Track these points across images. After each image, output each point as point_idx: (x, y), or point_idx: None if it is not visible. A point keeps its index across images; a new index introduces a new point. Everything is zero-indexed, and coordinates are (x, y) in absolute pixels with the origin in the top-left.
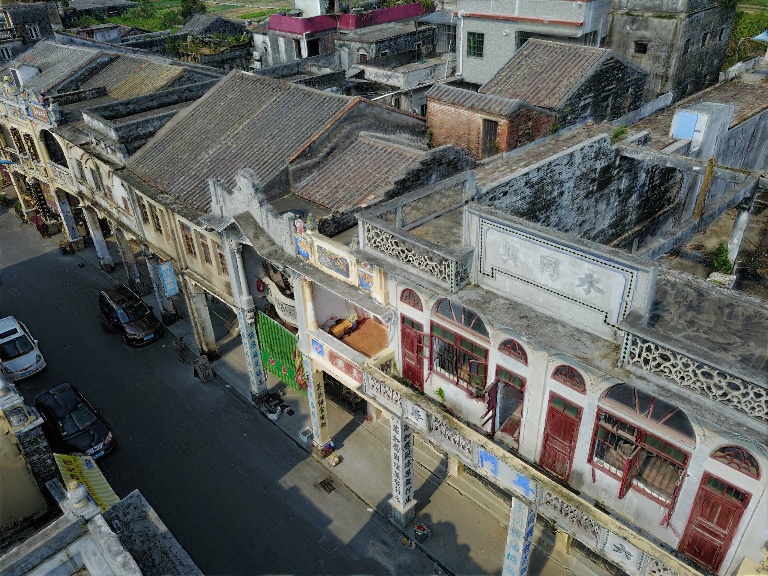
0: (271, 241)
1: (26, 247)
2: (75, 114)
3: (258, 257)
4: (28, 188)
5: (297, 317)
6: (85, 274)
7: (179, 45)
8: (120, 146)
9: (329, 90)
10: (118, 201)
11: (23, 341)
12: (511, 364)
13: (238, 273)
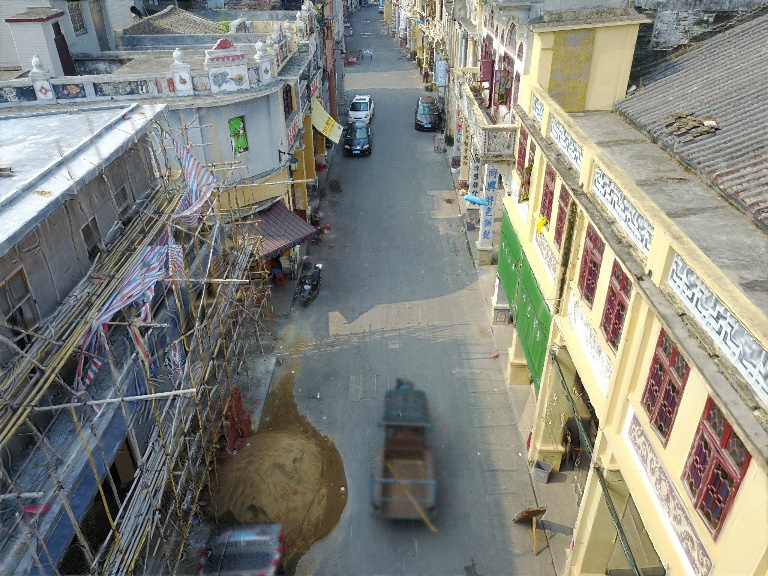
0: (466, 14)
1: (410, 84)
2: None
3: None
4: None
5: None
6: None
7: None
8: None
9: None
10: None
11: (365, 105)
12: (495, 43)
13: None
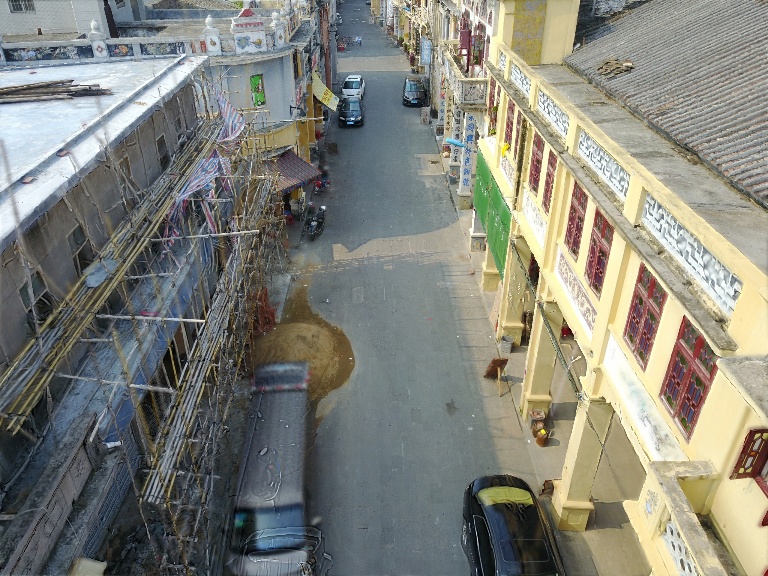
0: None
1: (398, 67)
2: None
3: None
4: None
5: None
6: None
7: None
8: None
9: None
10: None
11: (357, 84)
12: None
13: None
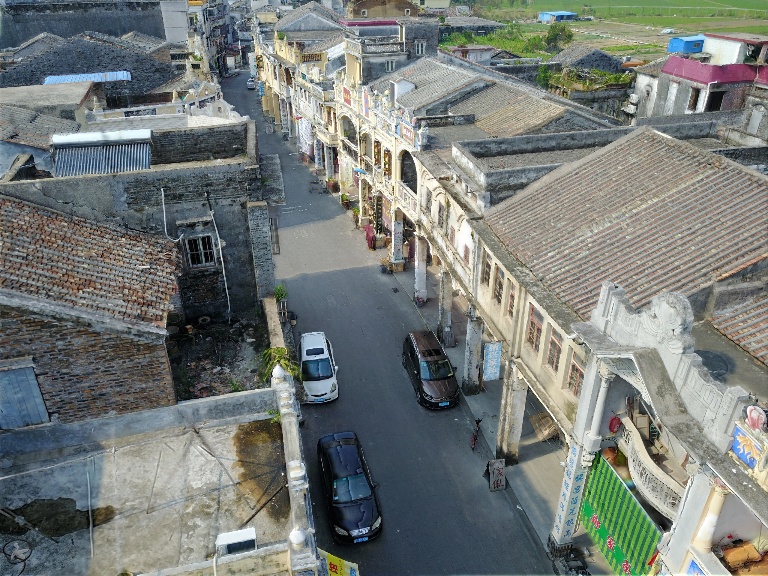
0: (681, 406)
1: (352, 254)
2: (439, 140)
3: (626, 389)
4: (370, 197)
5: (679, 518)
6: (397, 301)
7: (551, 76)
8: (485, 194)
9: (754, 167)
10: (459, 247)
11: (325, 364)
12: None
13: (595, 404)
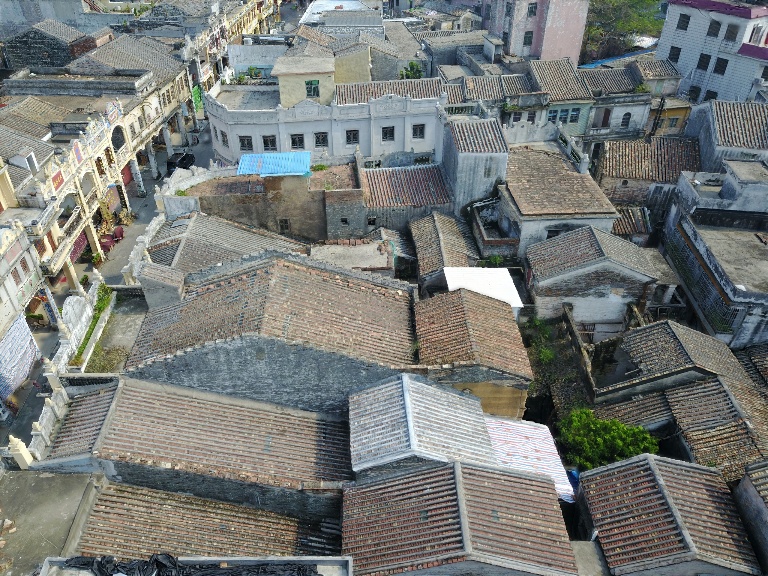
0: None
1: None
2: None
3: None
4: None
5: None
6: None
7: None
8: None
9: None
10: (153, 116)
11: None
12: None
13: None
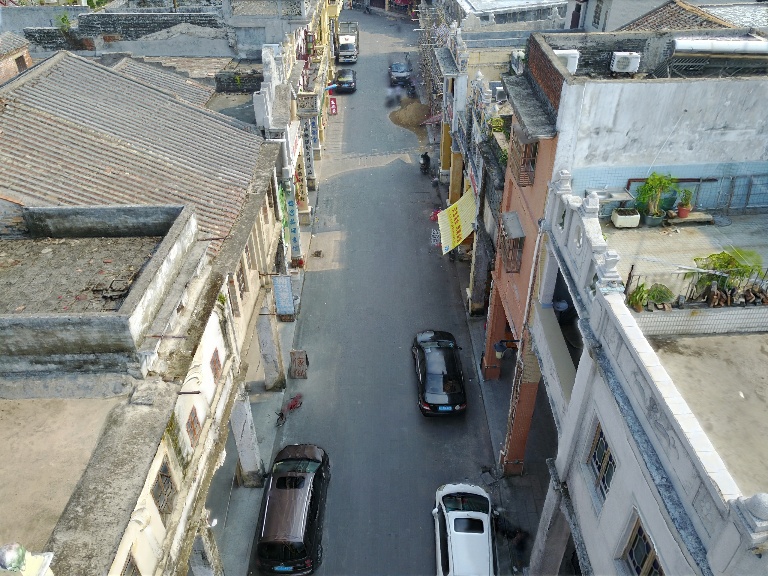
0: None
1: None
2: None
3: None
4: None
5: (289, 147)
6: None
7: None
8: (201, 234)
9: None
10: None
11: None
12: None
13: None
